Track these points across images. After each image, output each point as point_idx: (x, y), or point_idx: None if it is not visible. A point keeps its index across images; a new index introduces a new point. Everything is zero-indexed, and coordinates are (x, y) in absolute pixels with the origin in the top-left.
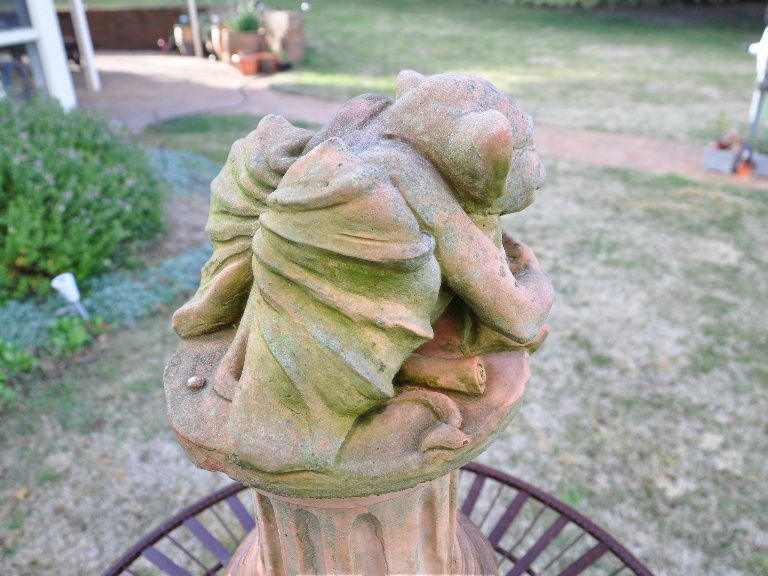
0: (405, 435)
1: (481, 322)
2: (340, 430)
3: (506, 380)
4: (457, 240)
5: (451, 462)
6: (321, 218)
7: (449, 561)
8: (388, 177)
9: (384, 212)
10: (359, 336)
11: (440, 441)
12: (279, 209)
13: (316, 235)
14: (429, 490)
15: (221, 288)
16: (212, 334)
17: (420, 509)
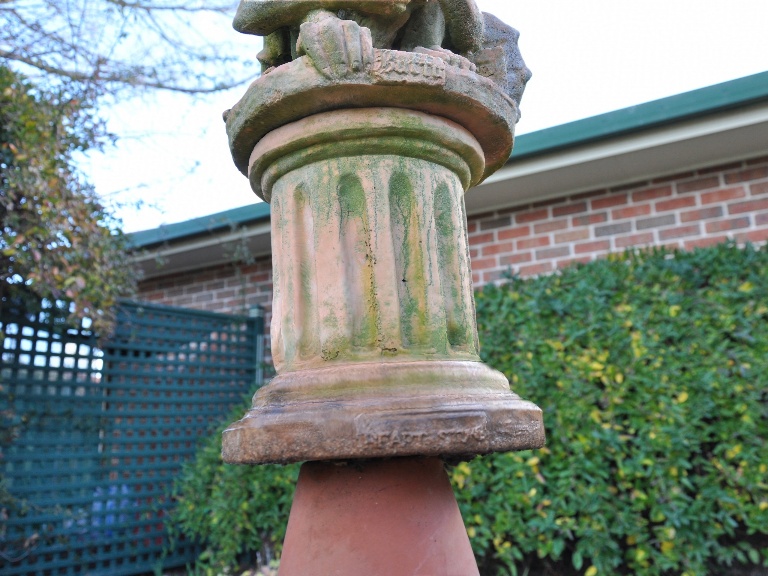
0: None
1: None
2: None
3: None
4: None
5: None
6: None
7: None
8: None
9: None
10: None
11: None
12: None
13: None
14: None
15: None
16: None
17: None
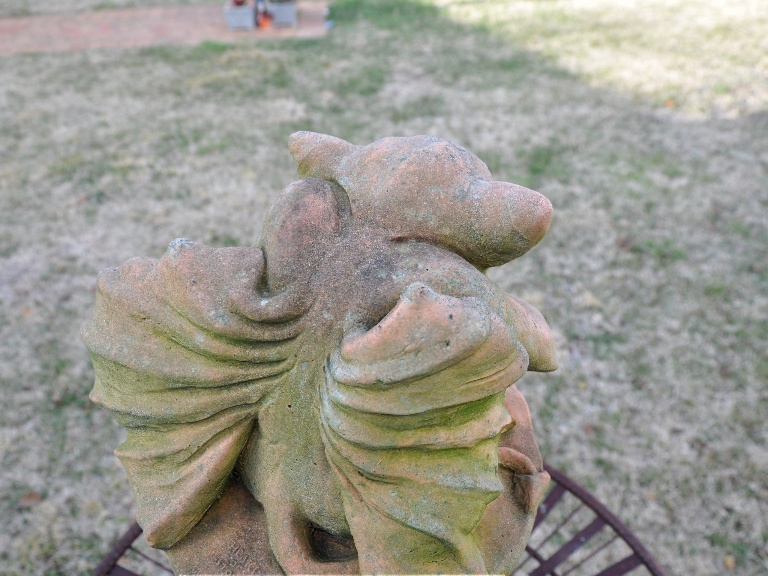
0: (508, 507)
1: None
2: (473, 545)
3: (510, 397)
4: (514, 321)
5: None
6: (445, 378)
7: None
8: None
9: (505, 343)
10: (475, 457)
11: (540, 494)
12: (384, 388)
13: (441, 396)
14: None
15: (217, 474)
16: (201, 522)
17: None
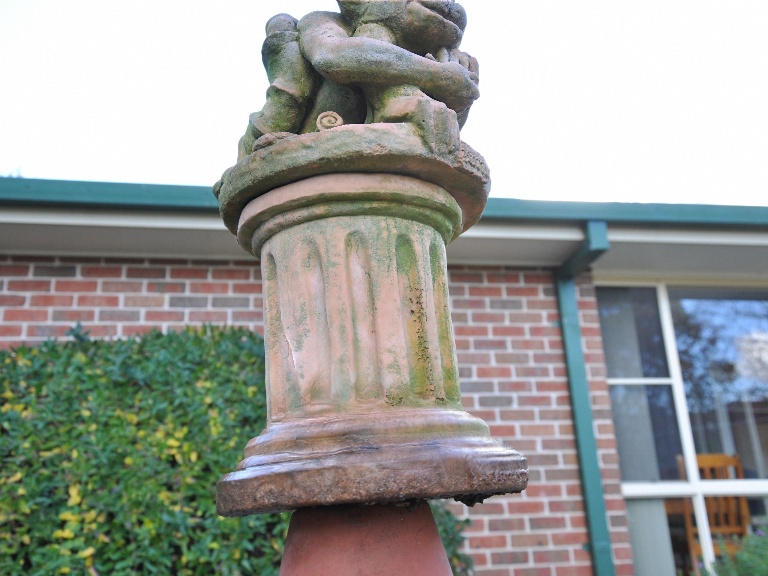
0: None
1: (375, 109)
2: None
3: None
4: None
5: (265, 161)
6: None
7: (377, 391)
8: None
9: None
10: None
11: None
12: None
13: None
14: (315, 246)
15: None
16: None
17: (319, 275)
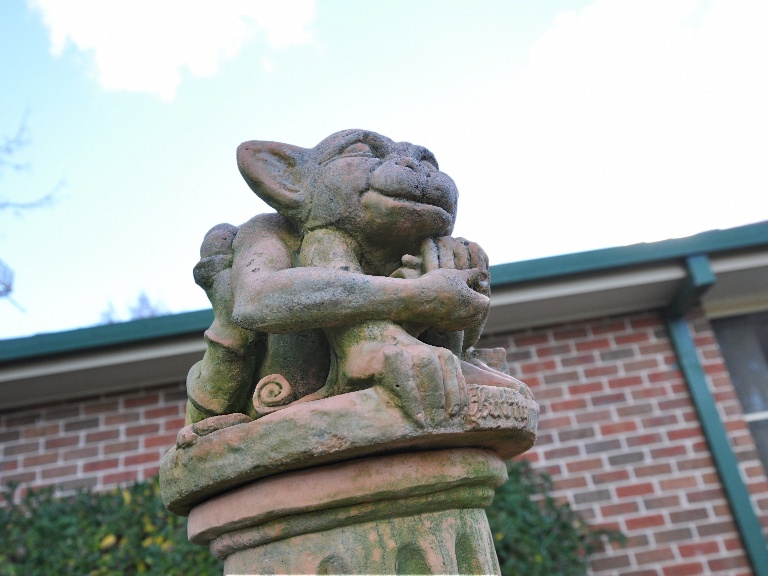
0: None
1: None
2: None
3: None
4: None
5: None
6: None
7: None
8: (232, 228)
9: None
10: None
11: None
12: None
13: None
14: None
15: None
16: None
17: None
